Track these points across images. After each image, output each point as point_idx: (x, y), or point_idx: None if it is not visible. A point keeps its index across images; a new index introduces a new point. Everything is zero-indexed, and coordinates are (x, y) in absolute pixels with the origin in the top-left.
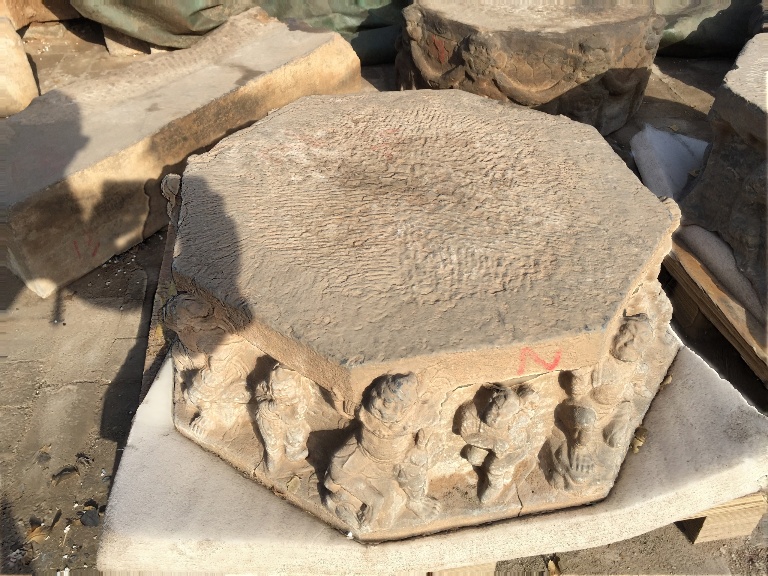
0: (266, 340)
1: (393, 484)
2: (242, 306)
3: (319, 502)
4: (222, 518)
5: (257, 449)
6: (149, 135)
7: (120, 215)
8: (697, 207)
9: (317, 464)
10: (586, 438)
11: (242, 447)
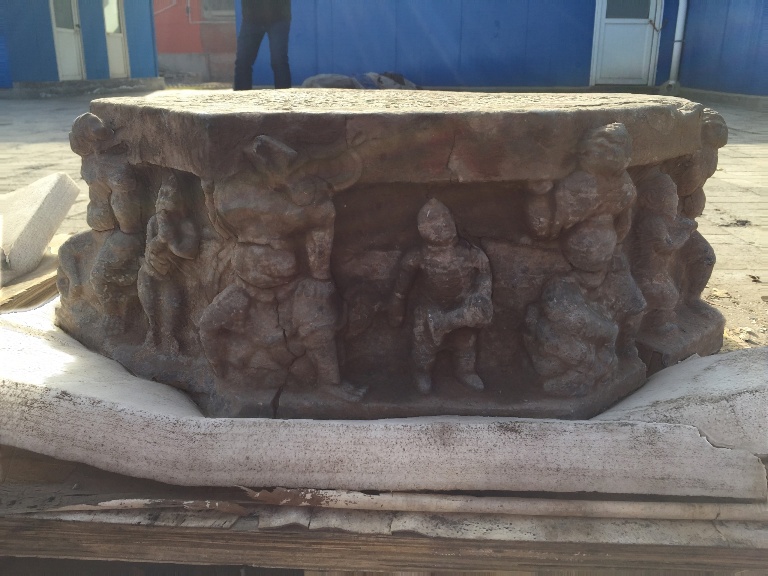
0: None
1: None
2: None
3: None
4: None
5: None
6: None
7: None
8: None
9: None
10: None
11: None
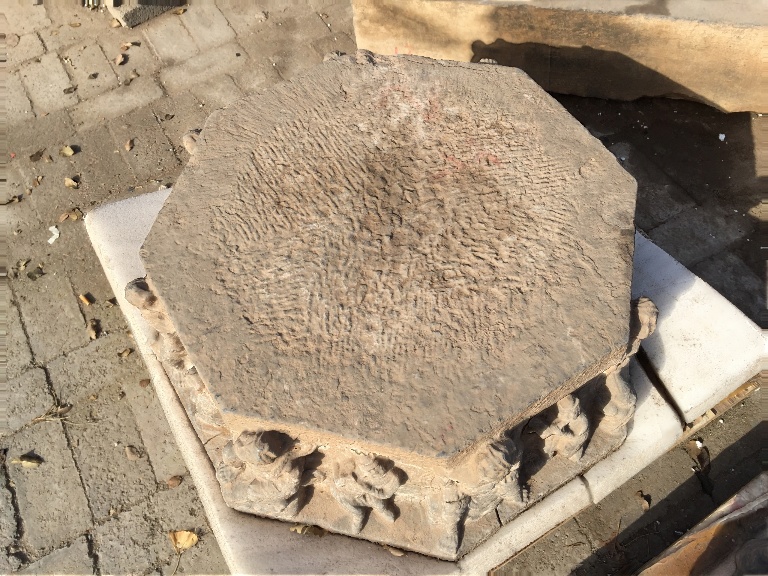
0: None
1: None
2: None
3: None
4: (136, 261)
5: None
6: (495, 4)
7: (442, 52)
8: (762, 564)
9: None
10: None
11: None
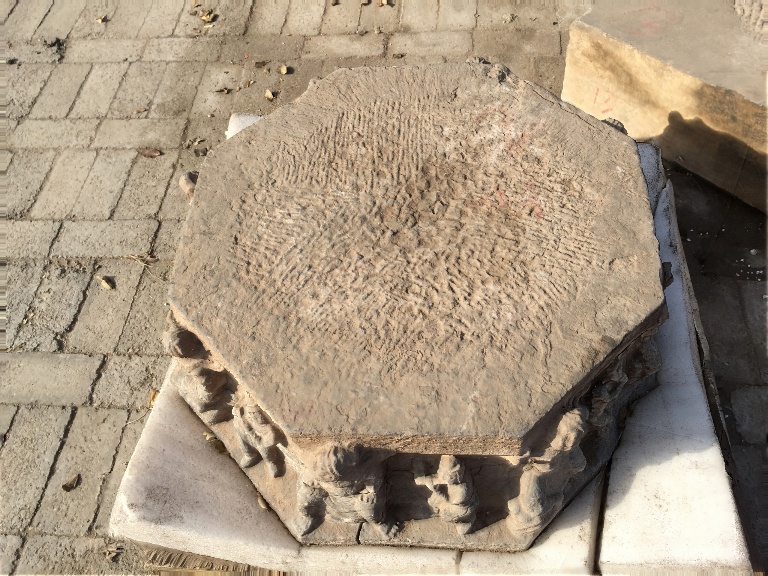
0: None
1: None
2: None
3: None
4: None
5: None
6: (704, 79)
7: (639, 109)
8: None
9: None
10: None
11: None
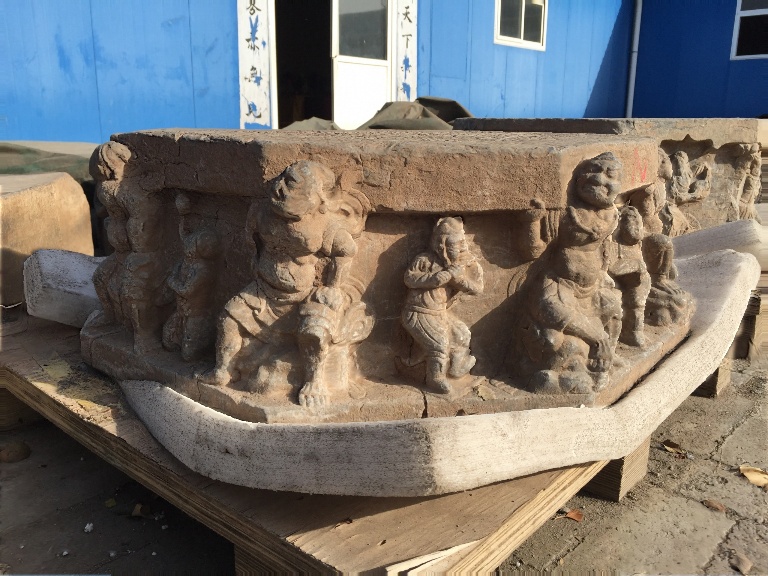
0: (429, 183)
1: (598, 320)
2: (391, 149)
3: (528, 393)
4: None
5: (405, 389)
6: None
7: None
8: None
9: (484, 373)
10: (671, 258)
11: (386, 395)
